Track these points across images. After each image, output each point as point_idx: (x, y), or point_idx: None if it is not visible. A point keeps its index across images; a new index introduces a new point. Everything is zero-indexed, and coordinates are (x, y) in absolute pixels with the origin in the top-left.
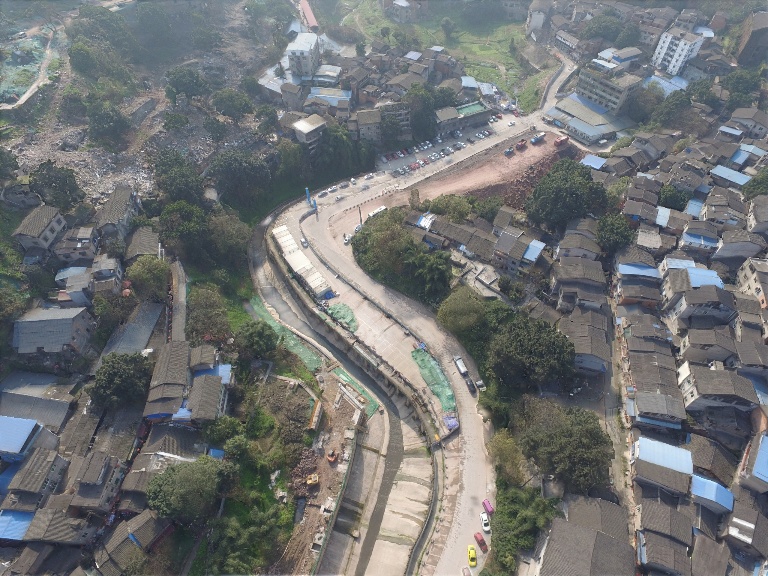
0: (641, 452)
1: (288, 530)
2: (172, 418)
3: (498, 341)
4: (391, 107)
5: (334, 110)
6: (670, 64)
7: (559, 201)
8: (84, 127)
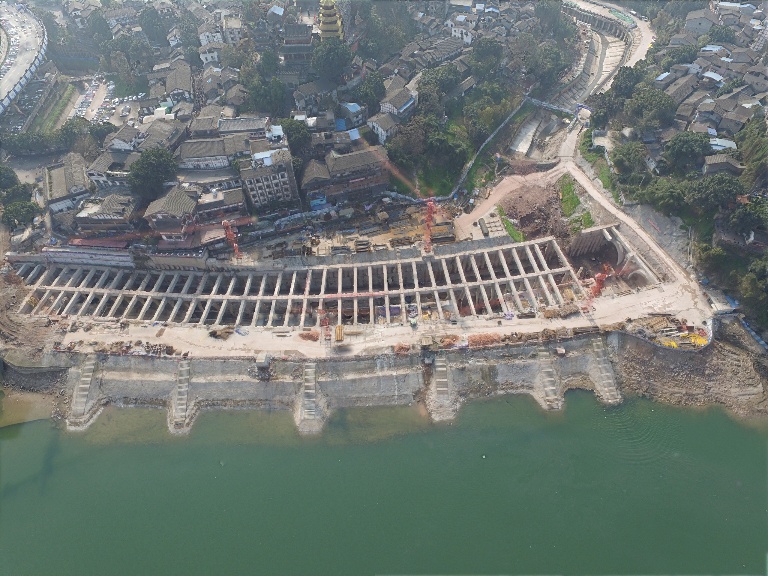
0: (721, 3)
1: None
2: None
3: None
4: None
5: None
6: None
7: None
8: None
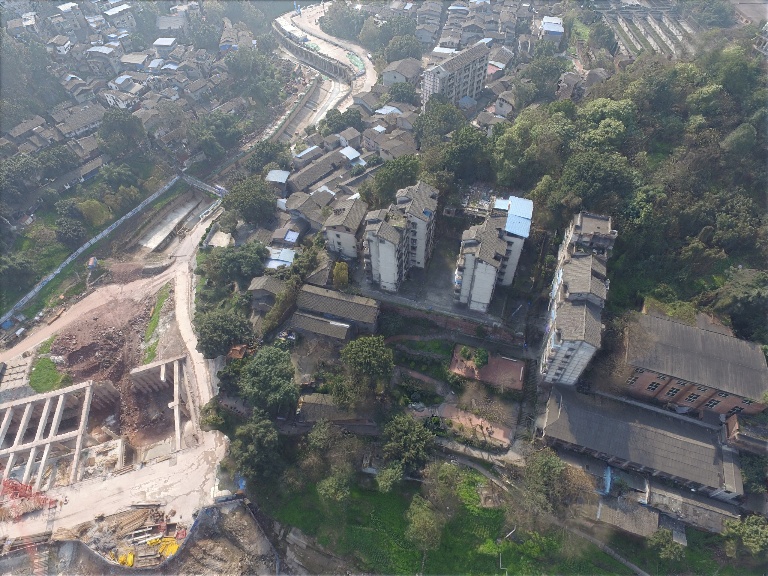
0: (434, 49)
1: (283, 99)
2: (232, 46)
3: None
4: None
5: None
6: None
7: None
8: None
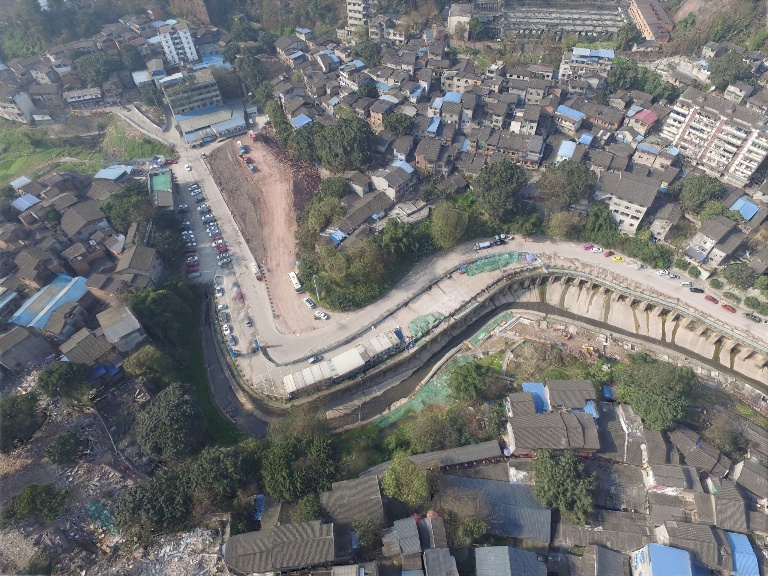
0: (567, 156)
1: None
2: None
3: (496, 196)
4: (138, 233)
5: (82, 303)
6: (187, 54)
7: (367, 135)
8: None
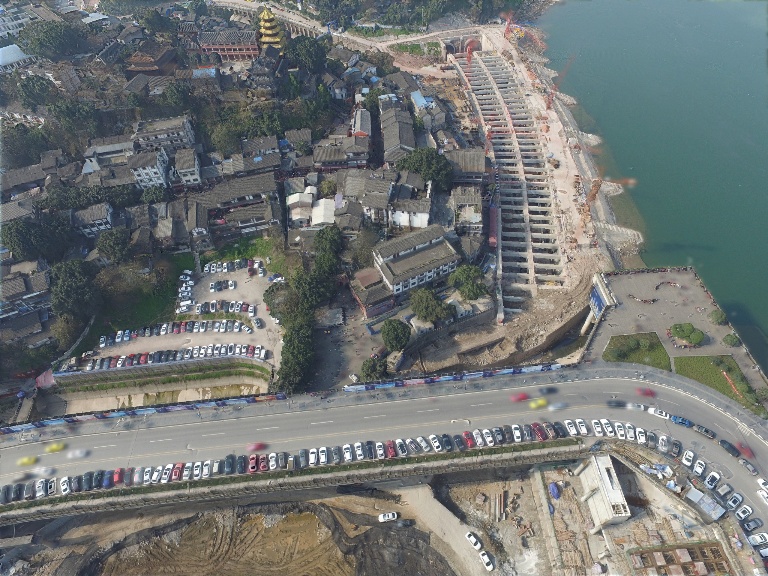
0: None
1: None
2: (171, 8)
3: None
4: None
5: None
6: None
7: None
8: None
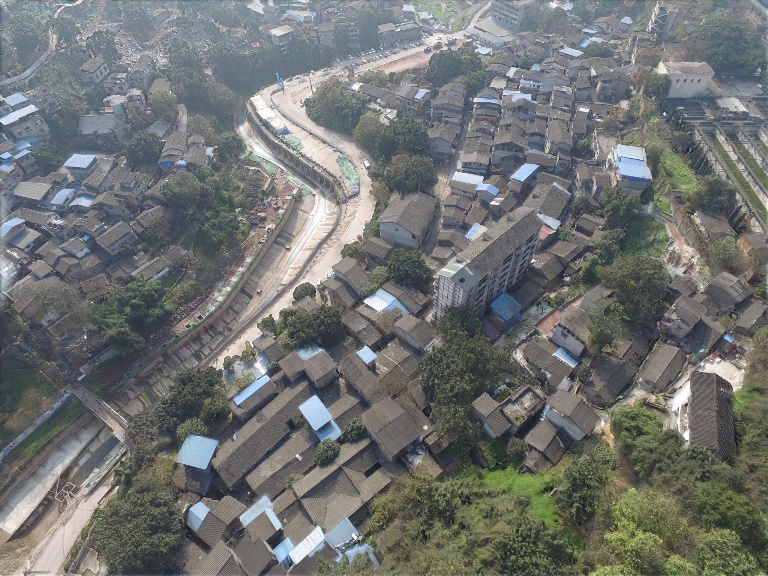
0: (454, 177)
1: (244, 236)
2: (175, 163)
3: None
4: (343, 20)
5: None
6: None
7: (442, 63)
8: (120, 23)
